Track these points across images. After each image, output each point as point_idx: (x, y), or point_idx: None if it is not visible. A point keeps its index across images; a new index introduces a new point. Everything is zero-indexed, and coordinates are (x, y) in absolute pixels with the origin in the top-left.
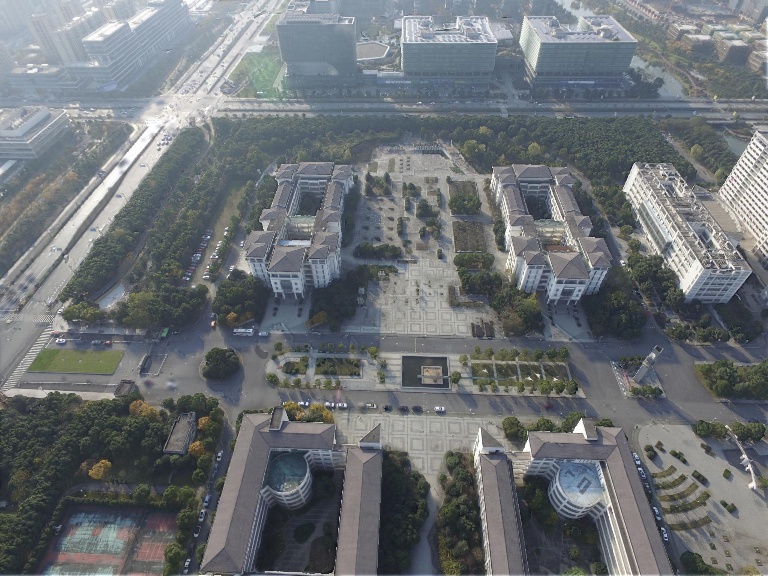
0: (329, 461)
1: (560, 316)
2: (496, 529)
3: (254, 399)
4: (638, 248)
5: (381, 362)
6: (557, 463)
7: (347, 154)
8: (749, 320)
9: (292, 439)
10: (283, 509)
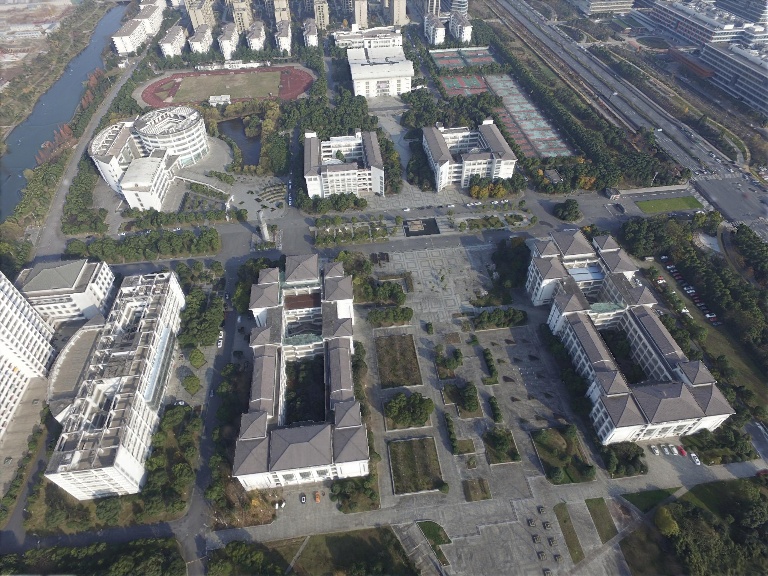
0: None
1: None
2: None
3: (528, 202)
4: None
5: (455, 228)
6: None
7: (667, 513)
8: None
9: None
10: None
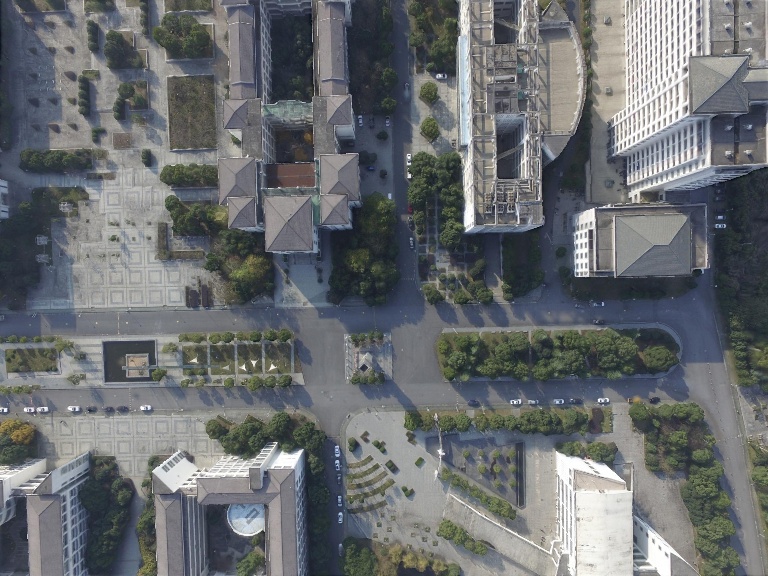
0: None
1: (299, 267)
2: (162, 563)
3: None
4: (435, 133)
5: (79, 352)
6: None
7: None
8: (534, 265)
9: None
10: None
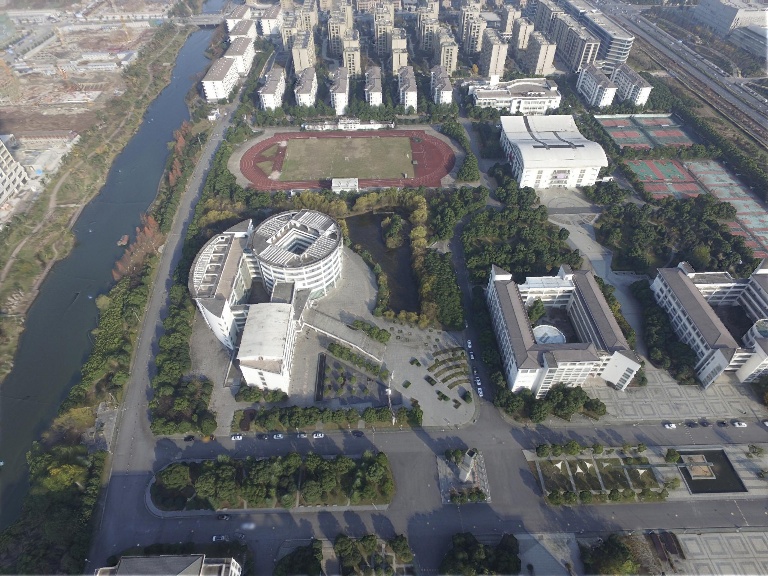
0: None
1: None
2: (605, 307)
3: None
4: None
5: (767, 481)
6: None
7: None
8: None
9: None
10: None
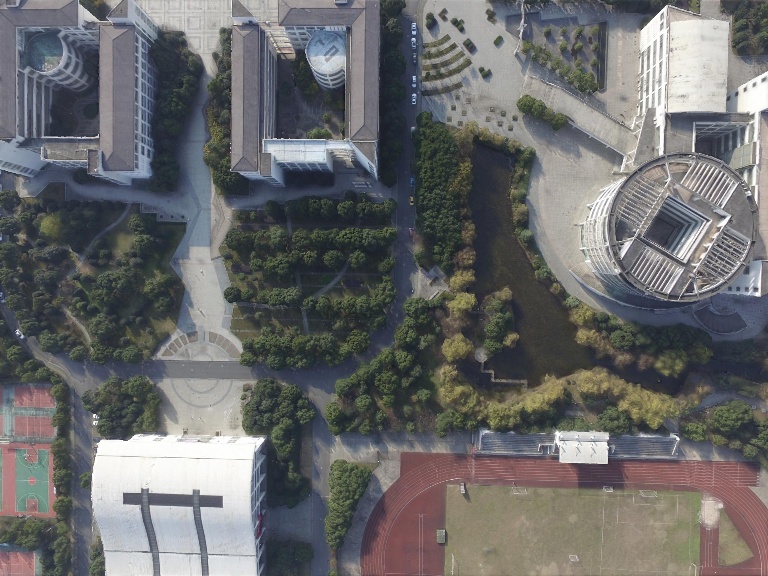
0: (95, 42)
1: None
2: (237, 96)
3: None
4: None
5: None
6: (309, 32)
7: None
8: None
9: (34, 16)
10: (69, 91)
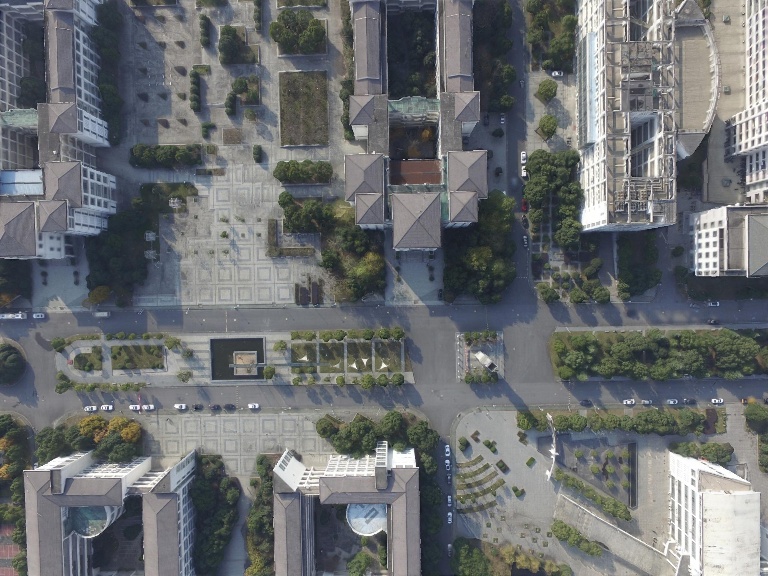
0: None
1: (411, 265)
2: (281, 563)
3: (53, 404)
4: None
5: (186, 349)
6: None
7: None
8: (651, 264)
9: (79, 500)
10: None
